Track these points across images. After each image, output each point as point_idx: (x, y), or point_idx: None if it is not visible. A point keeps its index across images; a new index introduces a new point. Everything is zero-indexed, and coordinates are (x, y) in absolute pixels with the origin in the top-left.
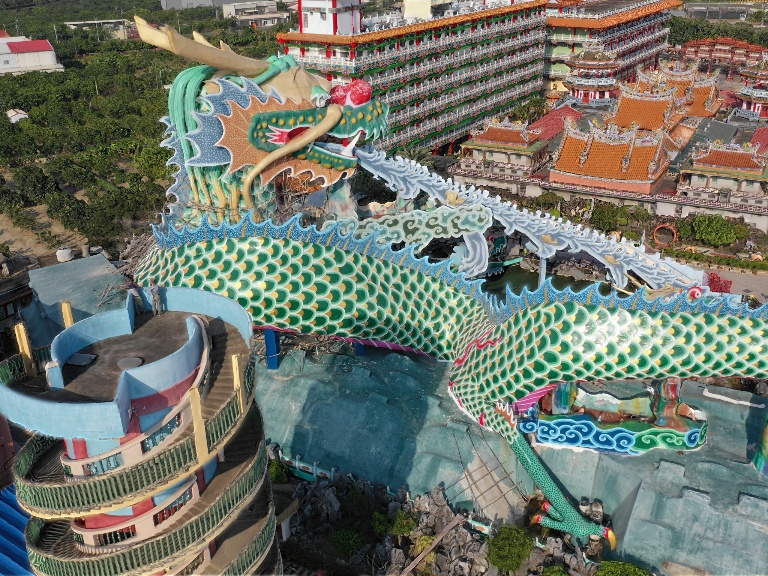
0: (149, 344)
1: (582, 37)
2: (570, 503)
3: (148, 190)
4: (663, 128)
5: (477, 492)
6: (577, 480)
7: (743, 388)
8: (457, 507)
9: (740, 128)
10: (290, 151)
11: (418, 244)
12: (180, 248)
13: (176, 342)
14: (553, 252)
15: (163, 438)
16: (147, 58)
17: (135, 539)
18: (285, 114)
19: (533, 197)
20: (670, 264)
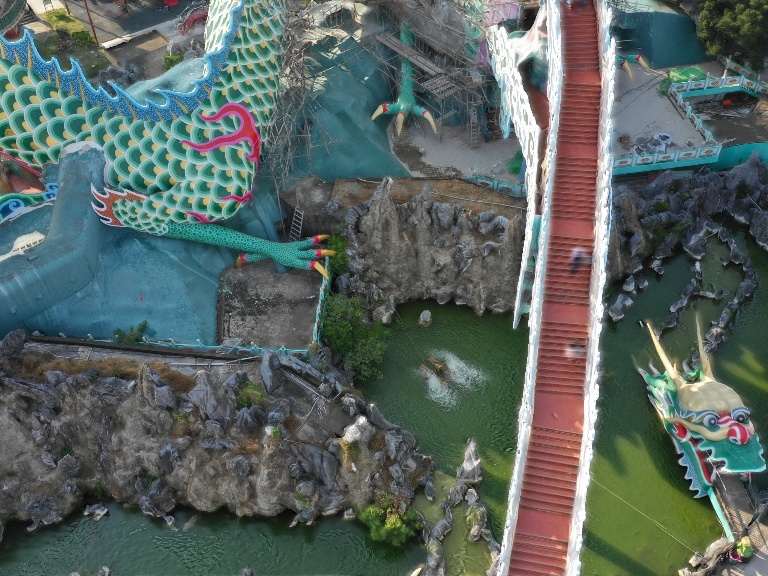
0: None
1: None
2: None
3: None
4: None
5: None
6: None
7: None
8: None
9: None
10: None
11: None
12: None
13: None
14: None
15: None
16: None
17: None
18: None
19: None
20: None
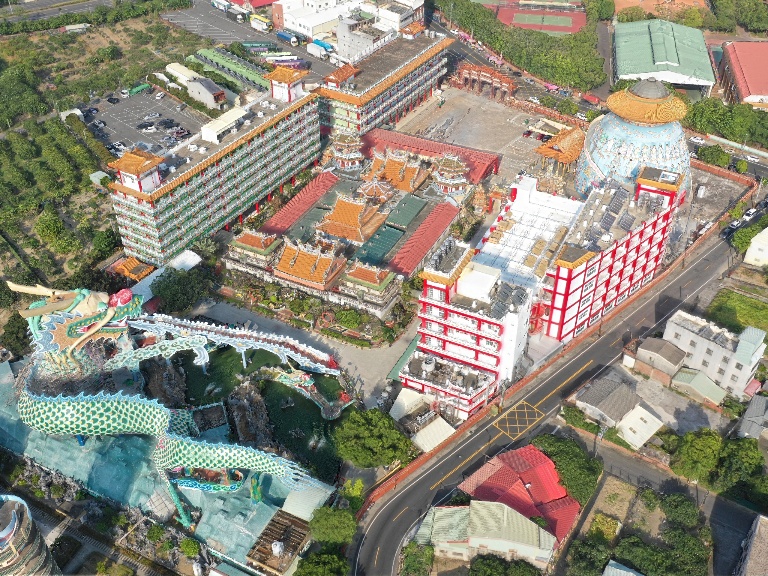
0: (3, 517)
1: (351, 107)
2: (189, 510)
3: (41, 266)
4: (333, 251)
5: (154, 507)
6: (195, 500)
7: (279, 453)
8: (147, 512)
9: (429, 201)
10: (89, 335)
11: (169, 354)
12: (35, 402)
13: (10, 516)
14: (245, 350)
15: (6, 546)
16: (52, 49)
17: (3, 567)
18: (84, 321)
19: (268, 281)
20: (311, 350)
